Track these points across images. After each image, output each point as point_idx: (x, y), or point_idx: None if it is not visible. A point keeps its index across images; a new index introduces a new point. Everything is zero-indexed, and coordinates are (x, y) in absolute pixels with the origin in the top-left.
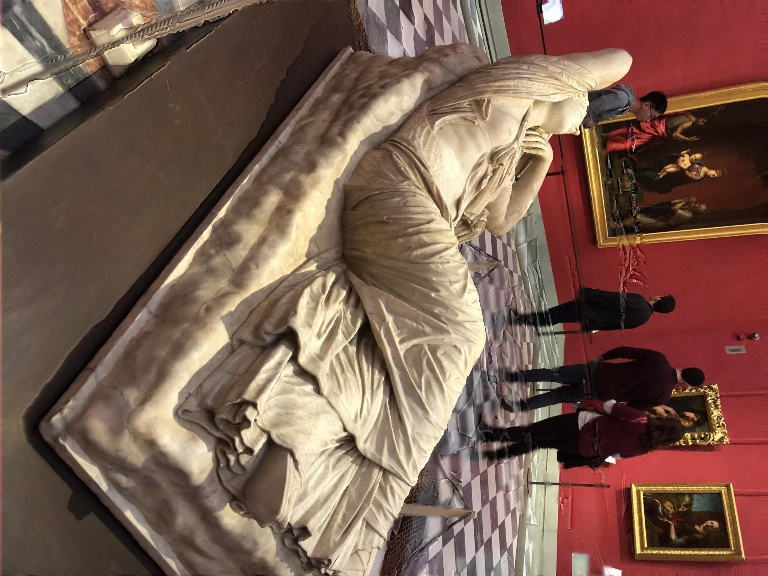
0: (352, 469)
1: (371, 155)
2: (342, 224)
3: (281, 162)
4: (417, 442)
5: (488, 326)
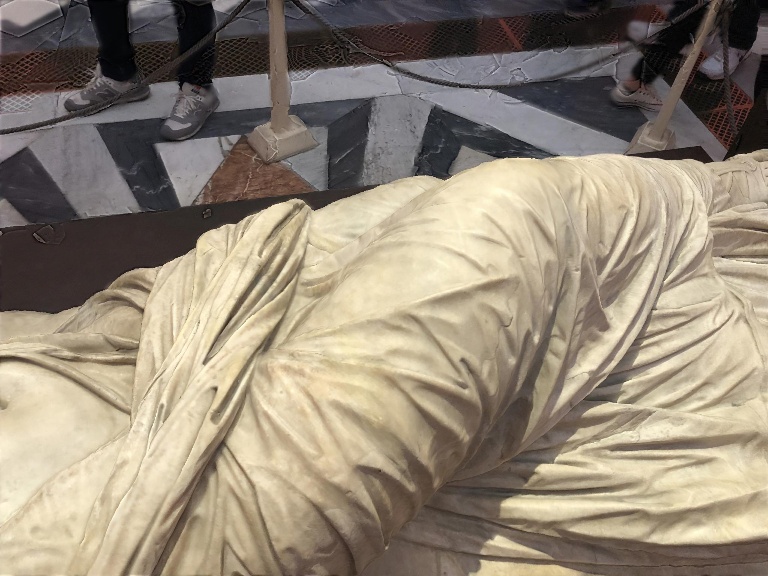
0: None
1: None
2: None
3: None
4: (681, 200)
5: None
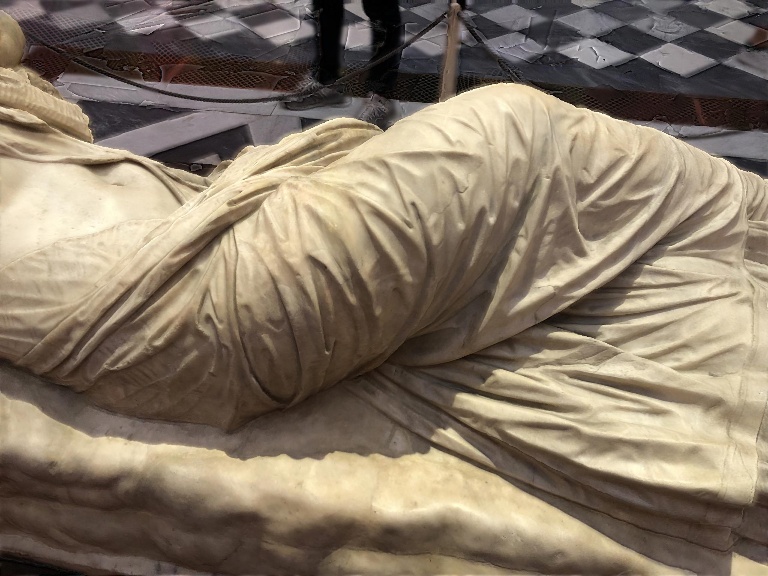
0: (747, 267)
1: (119, 404)
2: (305, 401)
3: (239, 567)
4: (710, 180)
5: (105, 7)
